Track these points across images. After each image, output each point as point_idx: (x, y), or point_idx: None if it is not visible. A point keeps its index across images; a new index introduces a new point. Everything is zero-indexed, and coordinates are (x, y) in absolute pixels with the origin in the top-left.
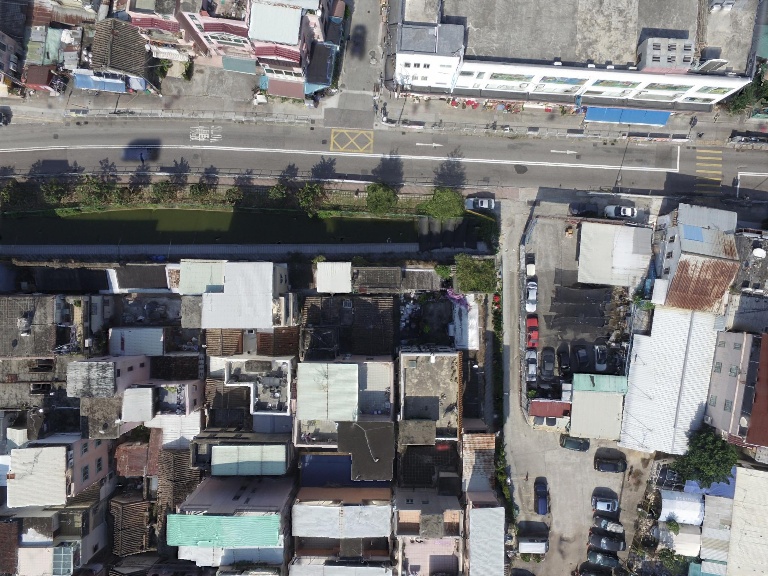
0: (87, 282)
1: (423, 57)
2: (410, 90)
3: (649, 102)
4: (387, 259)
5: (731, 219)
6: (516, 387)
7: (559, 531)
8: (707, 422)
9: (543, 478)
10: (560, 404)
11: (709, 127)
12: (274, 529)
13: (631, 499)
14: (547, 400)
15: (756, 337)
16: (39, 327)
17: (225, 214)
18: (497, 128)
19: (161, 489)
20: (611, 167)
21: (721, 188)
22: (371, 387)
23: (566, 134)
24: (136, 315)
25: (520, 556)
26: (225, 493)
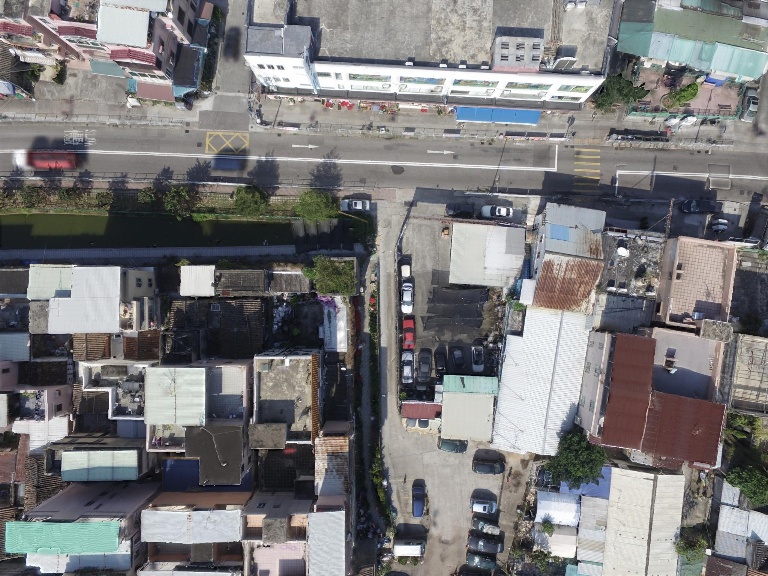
0: None
1: (271, 59)
2: (276, 92)
3: (518, 101)
4: (263, 262)
5: (599, 218)
6: (394, 389)
7: (438, 533)
8: (576, 423)
9: (421, 480)
10: (432, 406)
11: (587, 125)
12: (114, 535)
13: (511, 500)
14: (417, 402)
15: (614, 337)
16: None
17: (101, 218)
18: (373, 129)
19: (27, 495)
20: (488, 167)
21: (600, 187)
22: (226, 391)
23: (442, 134)
24: (9, 320)
25: (397, 559)
26: (81, 499)
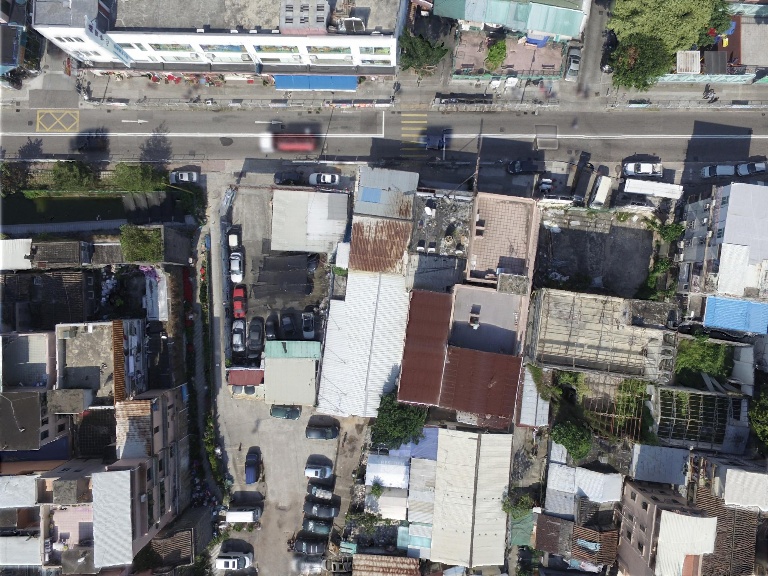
0: None
1: (61, 30)
2: (92, 66)
3: (332, 67)
4: None
5: (412, 180)
6: None
7: (274, 500)
8: (395, 383)
9: (257, 448)
10: (258, 372)
11: (413, 91)
12: None
13: (346, 465)
14: (240, 368)
15: None
16: None
17: None
18: (201, 102)
19: None
20: (316, 135)
21: (427, 151)
22: (34, 359)
23: (267, 104)
24: None
25: (233, 526)
26: None
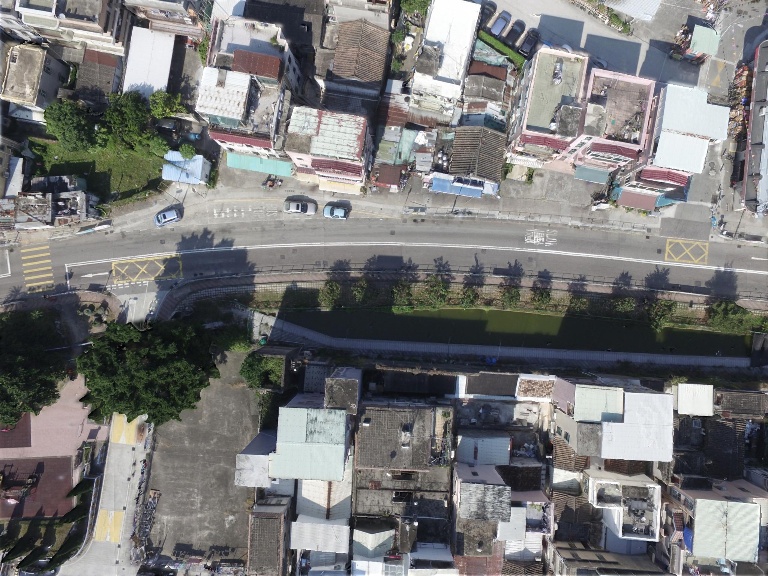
0: (435, 386)
1: None
2: None
3: None
4: (717, 373)
5: None
6: None
7: None
8: None
9: None
10: None
11: None
12: None
13: None
14: None
15: None
16: (417, 439)
17: (554, 318)
18: None
19: None
20: None
21: None
22: None
23: None
24: (469, 417)
25: None
26: None
